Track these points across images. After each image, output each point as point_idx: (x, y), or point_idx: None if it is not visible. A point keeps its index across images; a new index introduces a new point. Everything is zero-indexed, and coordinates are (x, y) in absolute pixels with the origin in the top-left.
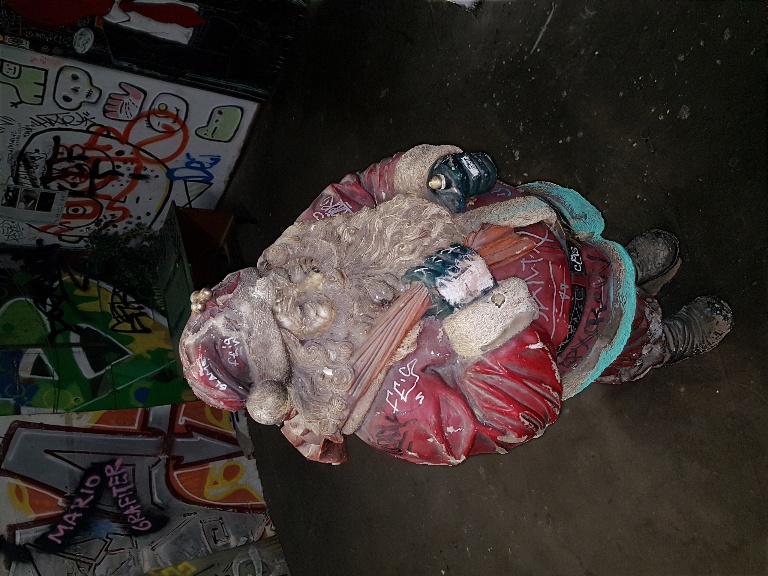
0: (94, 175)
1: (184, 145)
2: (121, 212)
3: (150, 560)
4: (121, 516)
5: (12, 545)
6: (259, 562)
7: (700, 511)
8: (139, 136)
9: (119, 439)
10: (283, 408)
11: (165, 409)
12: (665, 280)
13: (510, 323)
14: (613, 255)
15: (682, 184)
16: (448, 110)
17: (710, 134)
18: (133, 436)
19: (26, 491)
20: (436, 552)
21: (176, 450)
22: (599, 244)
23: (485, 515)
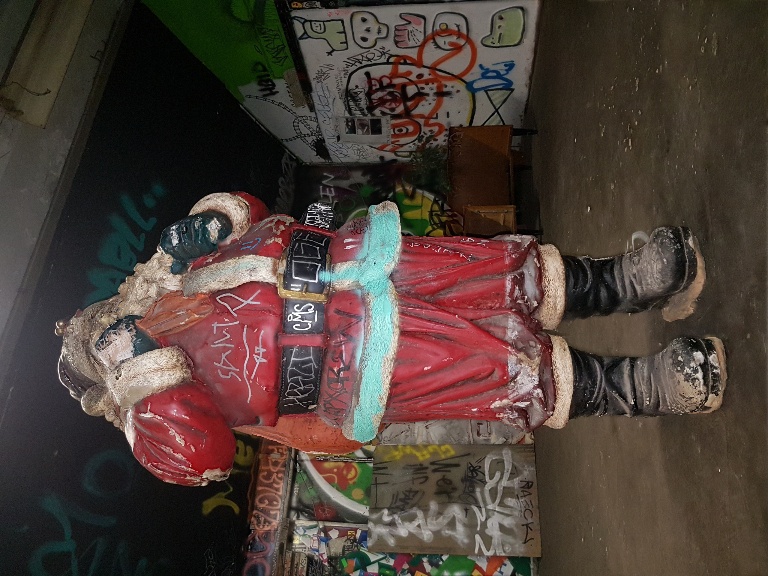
0: (406, 99)
1: (475, 57)
2: (437, 127)
3: (423, 435)
4: None
5: None
6: (510, 463)
7: None
8: (431, 58)
9: None
10: (96, 407)
11: None
12: (690, 297)
13: (127, 393)
14: (368, 310)
15: (713, 159)
16: (612, 14)
17: (729, 84)
18: None
19: None
20: (581, 519)
21: None
22: (364, 294)
23: (600, 503)
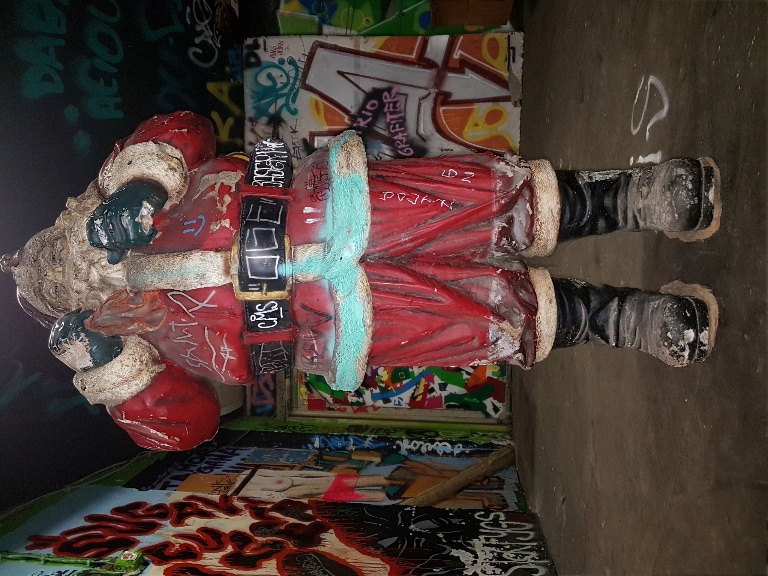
0: None
1: None
2: None
3: None
4: (391, 140)
5: (313, 147)
6: None
7: (640, 470)
8: None
9: (398, 67)
10: None
11: (442, 40)
12: None
13: (98, 401)
14: (338, 310)
15: (764, 106)
16: None
17: None
18: (410, 65)
19: (322, 106)
20: None
21: (446, 85)
22: (332, 289)
23: None
